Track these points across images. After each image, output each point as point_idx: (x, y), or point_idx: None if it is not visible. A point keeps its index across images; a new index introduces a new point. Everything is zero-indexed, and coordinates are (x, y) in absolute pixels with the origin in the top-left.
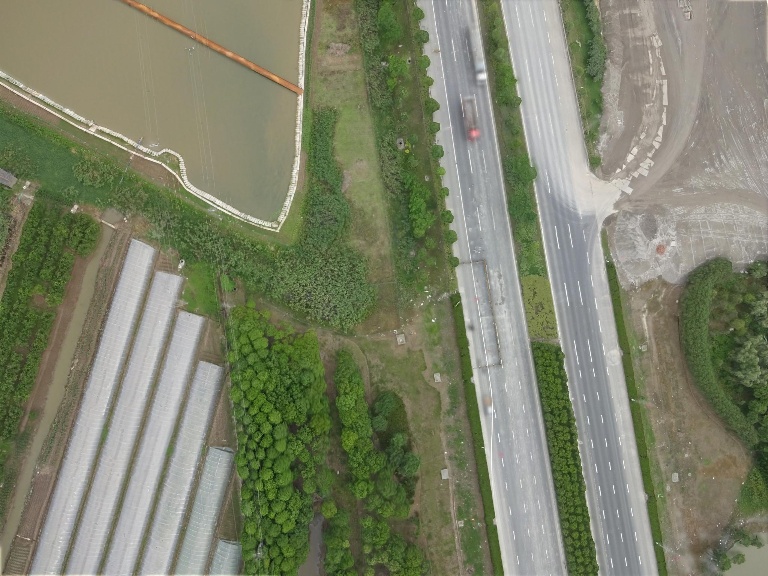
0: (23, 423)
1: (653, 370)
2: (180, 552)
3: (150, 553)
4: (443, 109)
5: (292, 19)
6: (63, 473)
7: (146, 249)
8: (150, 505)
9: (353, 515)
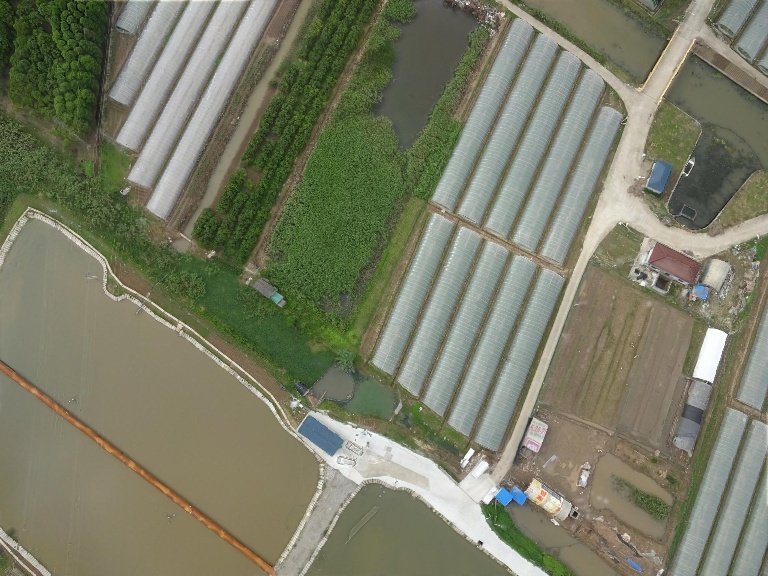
0: None
1: None
2: None
3: None
4: None
5: None
6: None
7: None
8: None
9: None
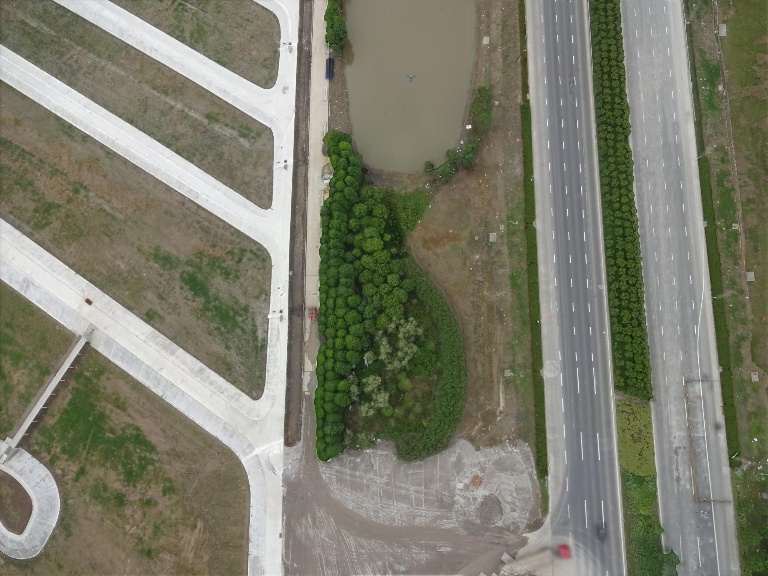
0: None
1: (500, 349)
2: None
3: None
4: None
5: None
6: None
7: None
8: None
9: None
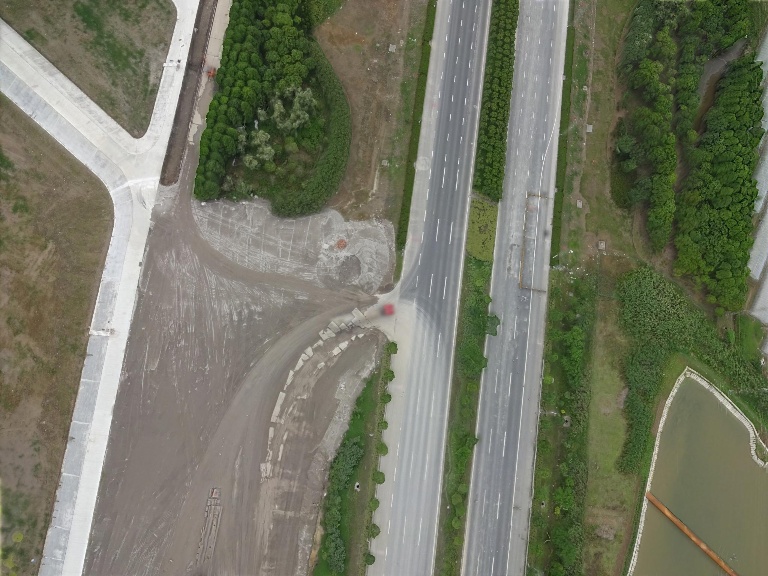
0: None
1: (382, 141)
2: None
3: None
4: (524, 445)
5: (642, 573)
6: None
7: None
8: None
9: None
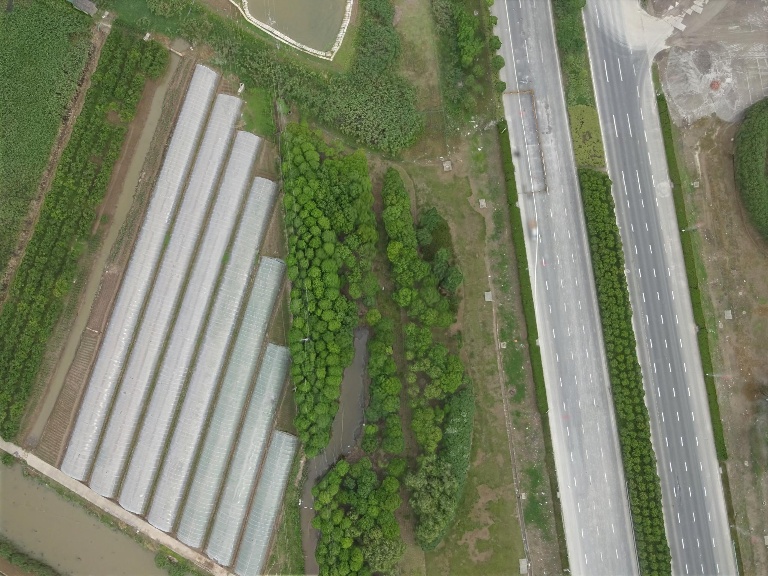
0: (95, 227)
1: (706, 207)
2: (232, 352)
3: (205, 351)
4: None
5: None
6: (129, 272)
7: (209, 74)
8: (206, 307)
9: (397, 330)
